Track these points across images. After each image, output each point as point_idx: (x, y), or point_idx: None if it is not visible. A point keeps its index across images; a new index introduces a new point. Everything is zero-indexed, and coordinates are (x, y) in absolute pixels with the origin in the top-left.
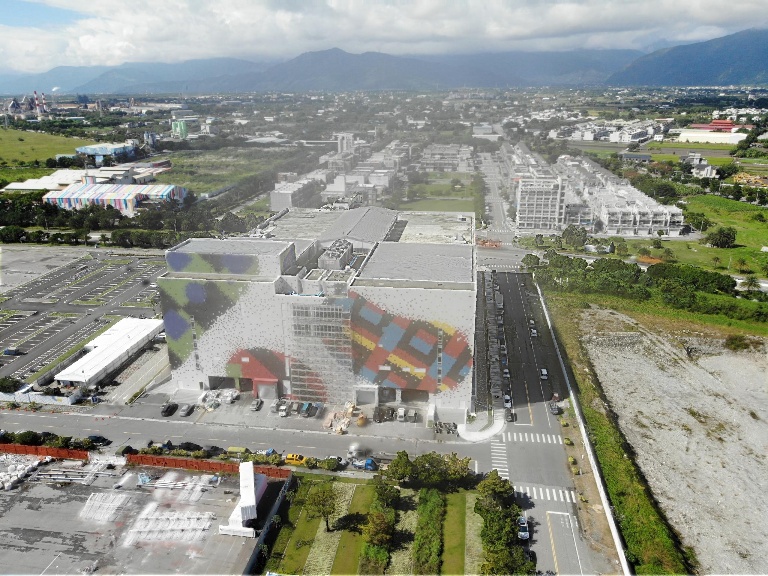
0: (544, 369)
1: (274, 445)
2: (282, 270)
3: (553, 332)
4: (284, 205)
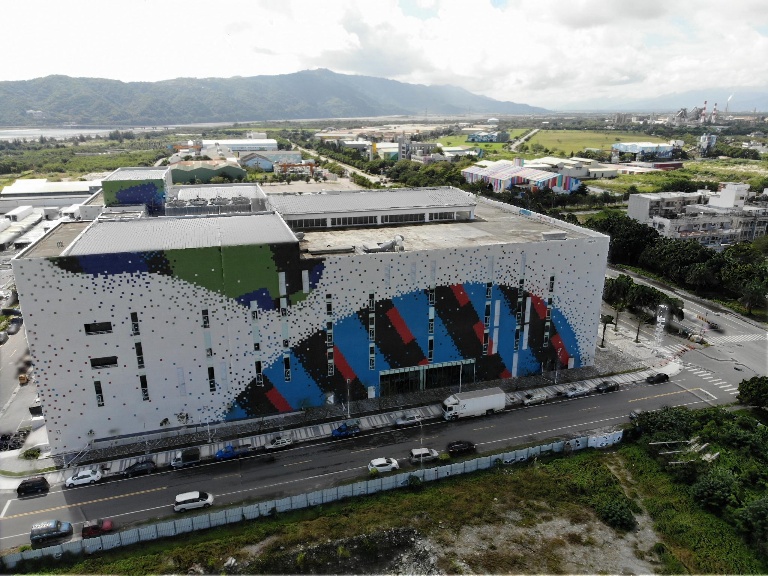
0: (196, 494)
1: (7, 358)
2: (113, 200)
3: (403, 488)
4: (640, 214)
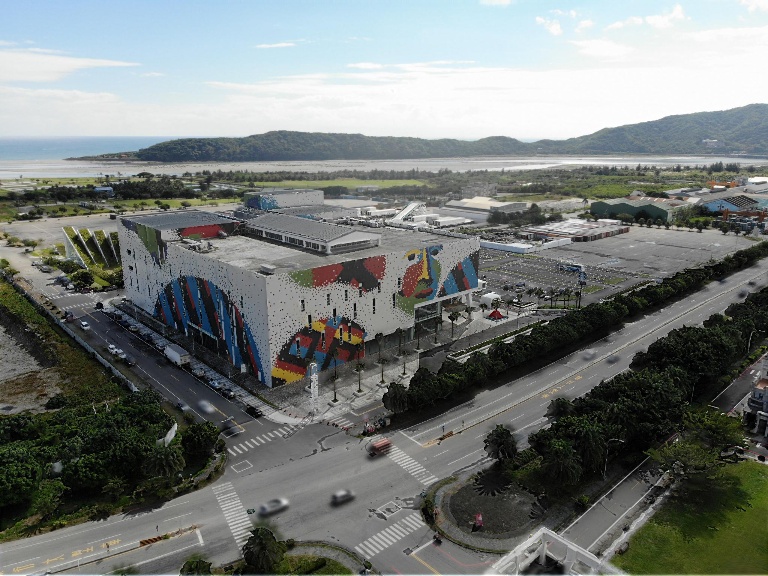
0: (86, 323)
1: None
2: None
3: None
4: None
